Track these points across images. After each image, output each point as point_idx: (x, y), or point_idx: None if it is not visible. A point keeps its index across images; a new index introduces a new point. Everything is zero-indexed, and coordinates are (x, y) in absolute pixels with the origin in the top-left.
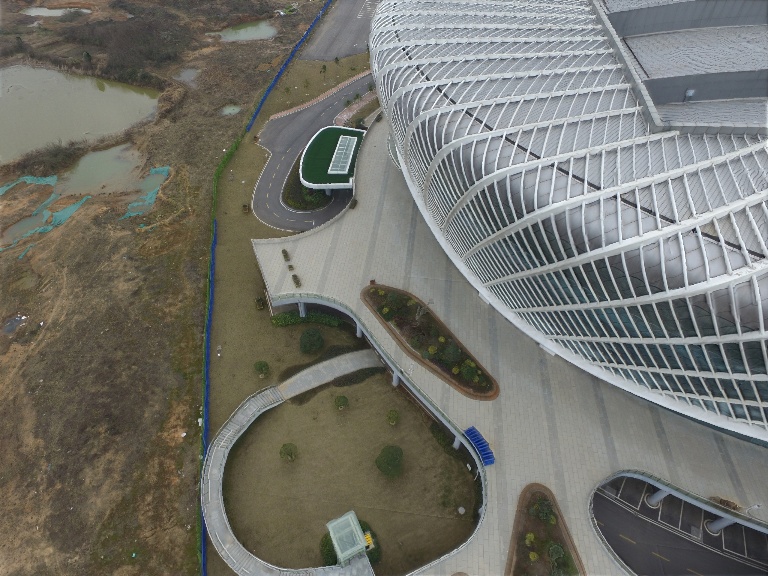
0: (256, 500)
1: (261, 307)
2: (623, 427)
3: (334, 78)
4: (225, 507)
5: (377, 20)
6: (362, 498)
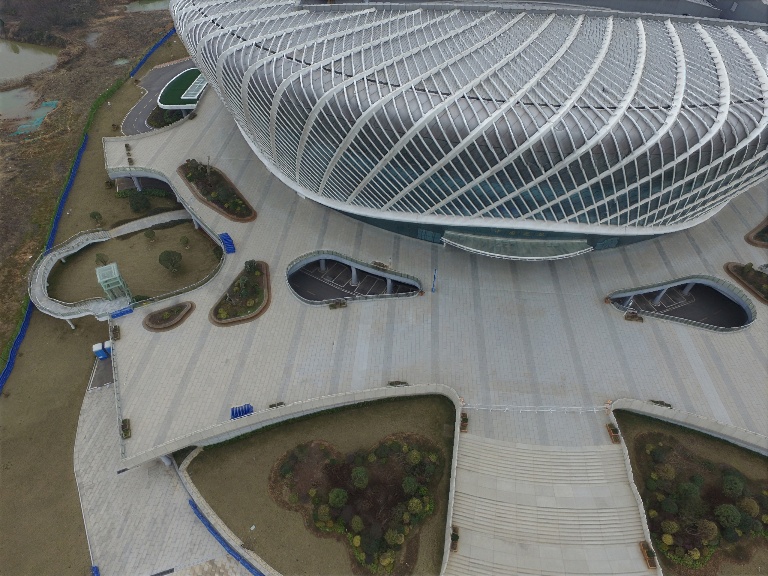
0: (75, 289)
1: (109, 187)
2: (334, 233)
3: None
4: (51, 292)
5: None
6: (151, 286)
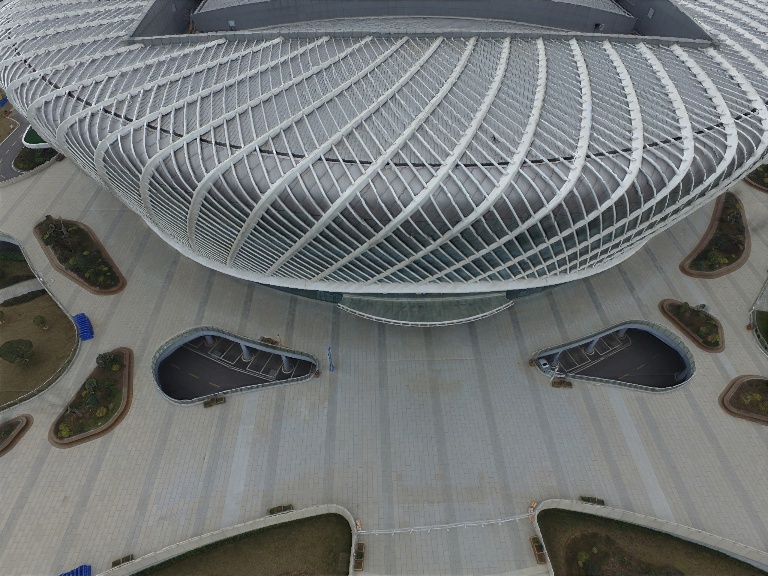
0: None
1: None
2: (218, 301)
3: None
4: None
5: None
6: None
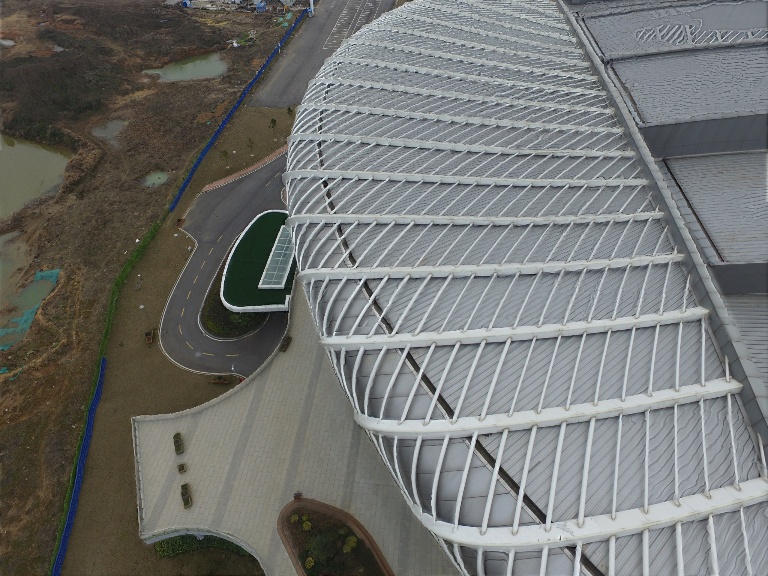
0: None
1: None
2: None
3: (287, 131)
4: None
5: (301, 113)
6: None
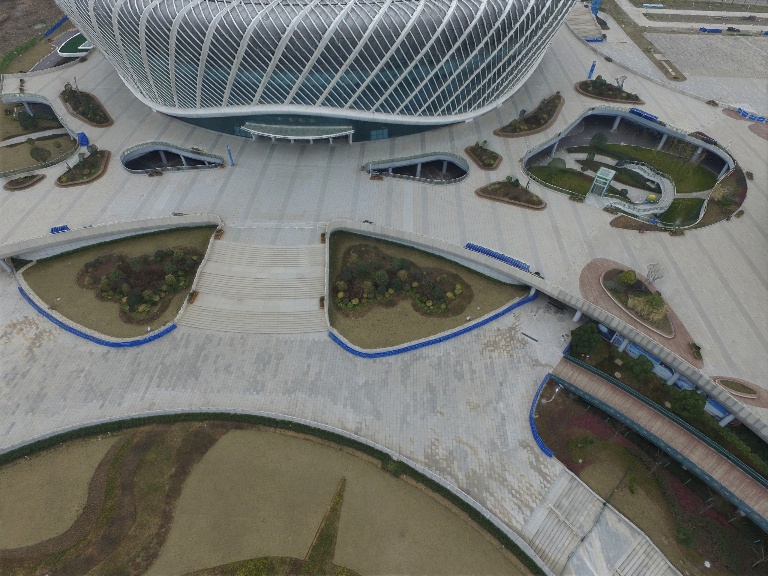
0: None
1: (7, 113)
2: (171, 133)
3: None
4: None
5: None
6: None
